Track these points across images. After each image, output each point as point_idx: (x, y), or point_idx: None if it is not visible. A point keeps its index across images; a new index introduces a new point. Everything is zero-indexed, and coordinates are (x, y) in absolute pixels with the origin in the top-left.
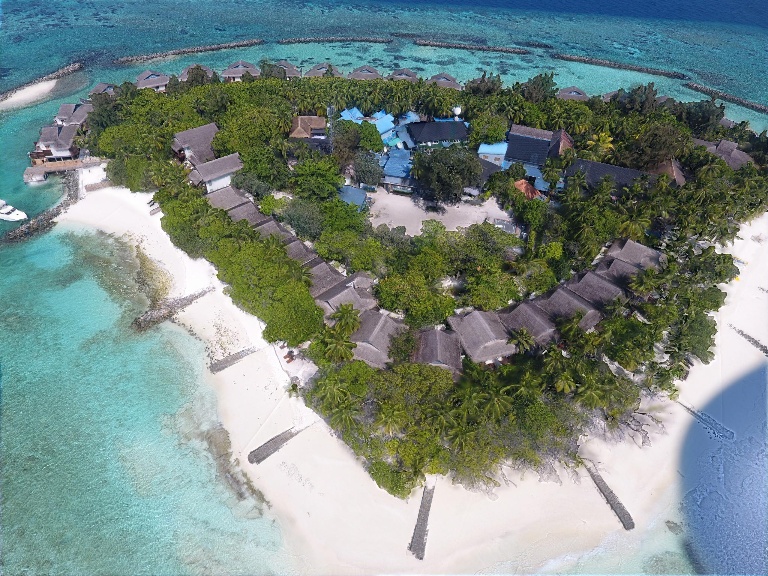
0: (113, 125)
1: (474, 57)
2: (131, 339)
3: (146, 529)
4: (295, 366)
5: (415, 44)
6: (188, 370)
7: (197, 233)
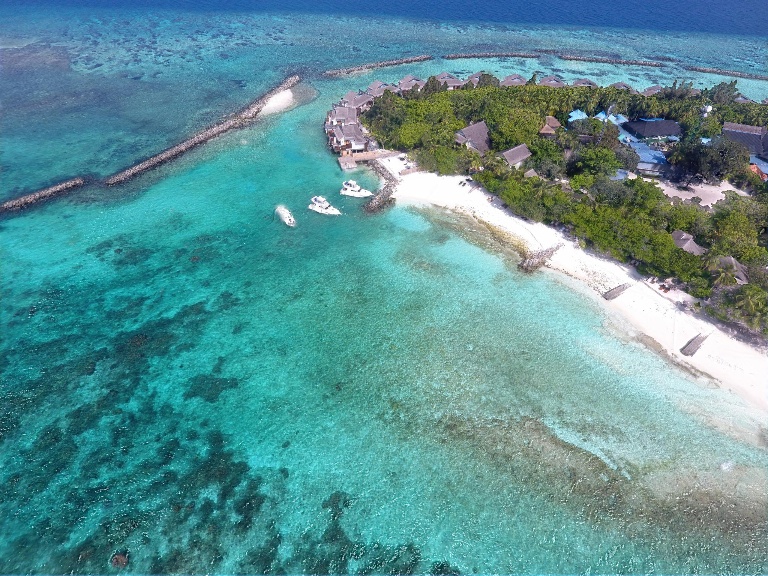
0: (404, 123)
1: (619, 69)
2: (526, 279)
3: (644, 394)
4: (673, 294)
5: (561, 59)
6: (587, 299)
7: (543, 202)
